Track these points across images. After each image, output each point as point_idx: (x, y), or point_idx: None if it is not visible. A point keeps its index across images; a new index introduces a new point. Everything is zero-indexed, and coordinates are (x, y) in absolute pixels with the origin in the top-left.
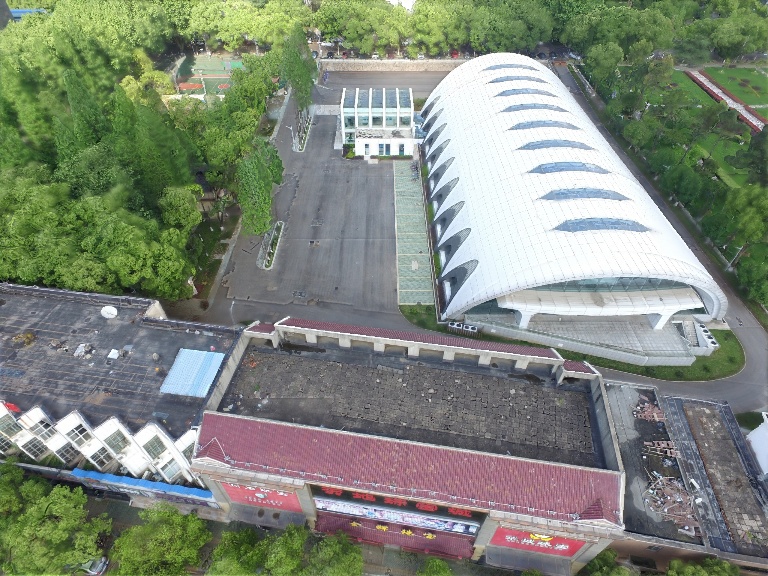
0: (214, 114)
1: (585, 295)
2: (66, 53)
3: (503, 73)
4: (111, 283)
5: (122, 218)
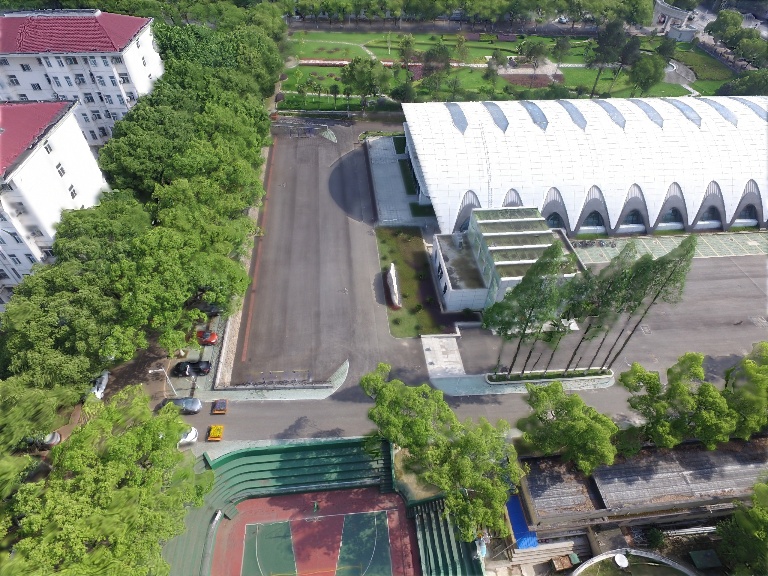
0: None
1: None
2: None
3: (481, 118)
4: None
5: None
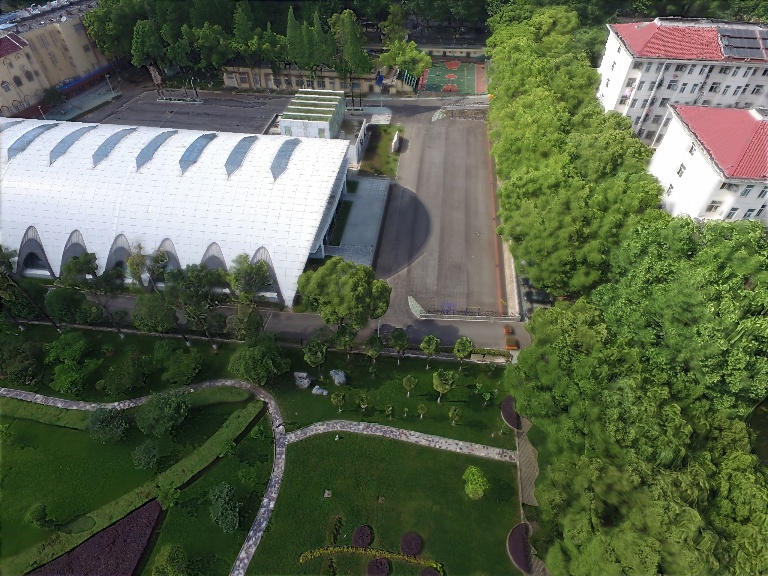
0: None
1: None
2: None
3: (267, 143)
4: None
5: (114, 8)
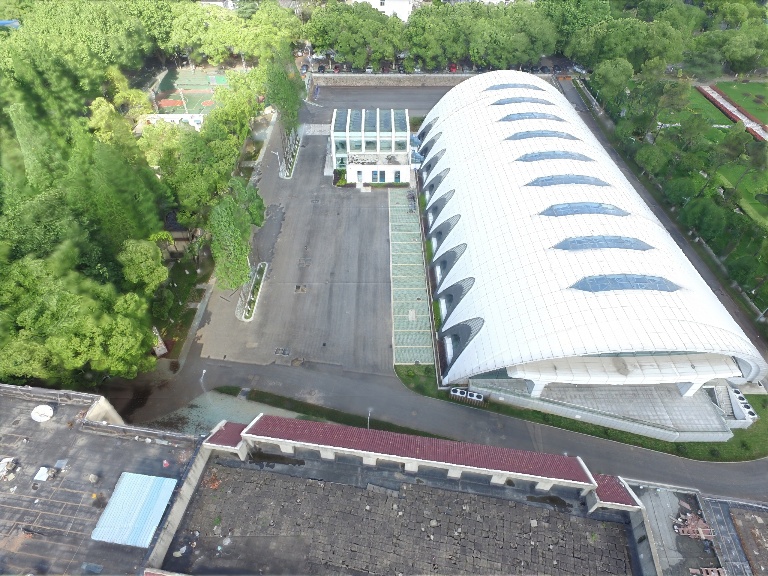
0: (188, 145)
1: (606, 360)
2: (26, 76)
3: (506, 94)
4: (52, 366)
5: (68, 285)
